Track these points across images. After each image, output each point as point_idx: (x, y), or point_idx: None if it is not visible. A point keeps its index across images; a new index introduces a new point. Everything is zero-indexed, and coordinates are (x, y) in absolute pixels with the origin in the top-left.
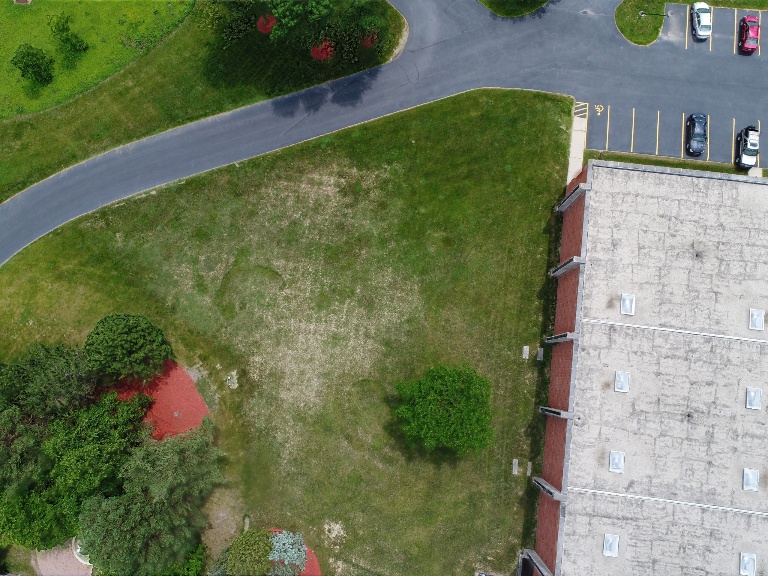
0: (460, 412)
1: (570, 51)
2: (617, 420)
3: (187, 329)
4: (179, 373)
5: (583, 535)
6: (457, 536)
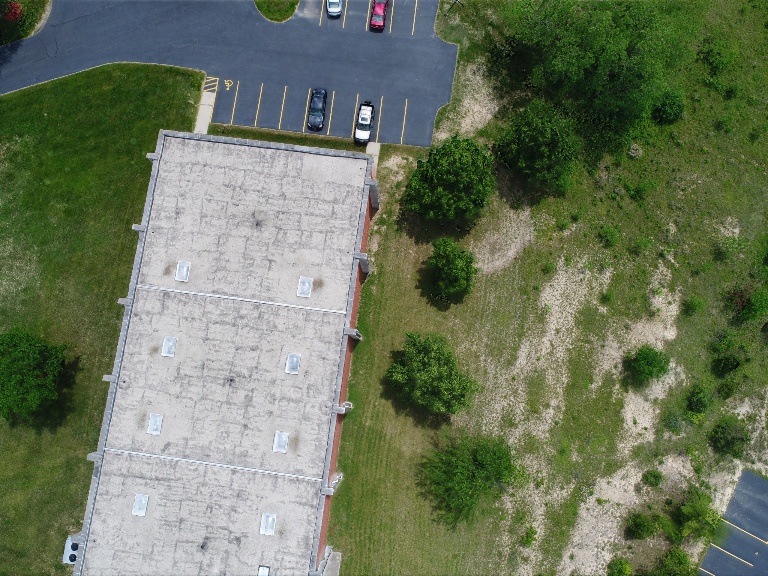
0: (1, 374)
1: (206, 27)
2: (161, 384)
3: None
4: None
5: (115, 495)
6: (52, 500)
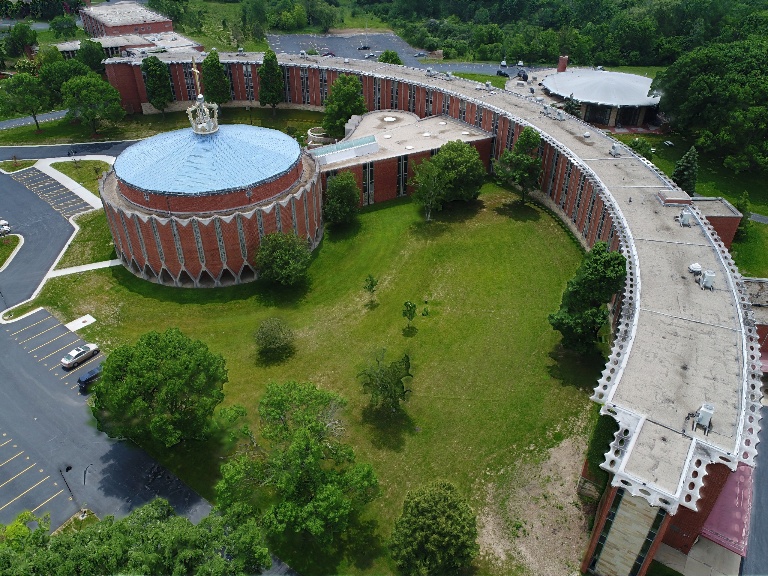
0: None
1: None
2: None
3: None
4: None
5: None
6: None
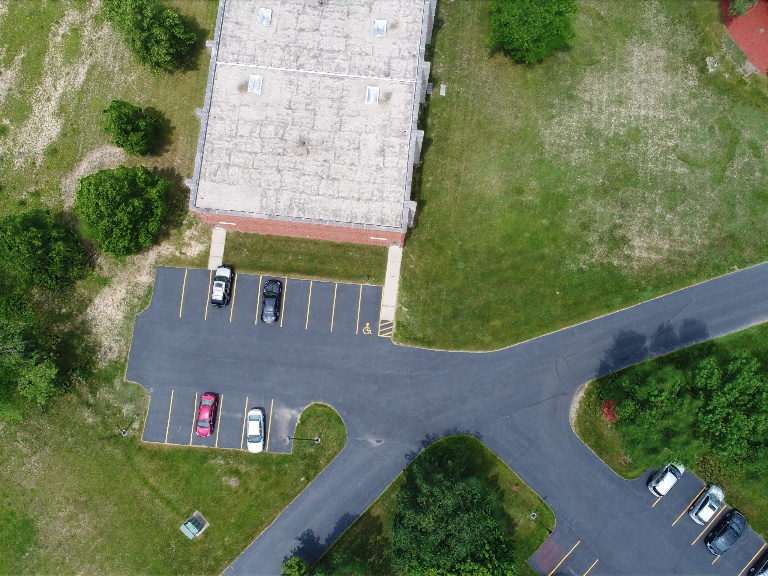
0: None
1: (396, 395)
2: None
3: (762, 108)
4: (764, 66)
5: None
6: None
